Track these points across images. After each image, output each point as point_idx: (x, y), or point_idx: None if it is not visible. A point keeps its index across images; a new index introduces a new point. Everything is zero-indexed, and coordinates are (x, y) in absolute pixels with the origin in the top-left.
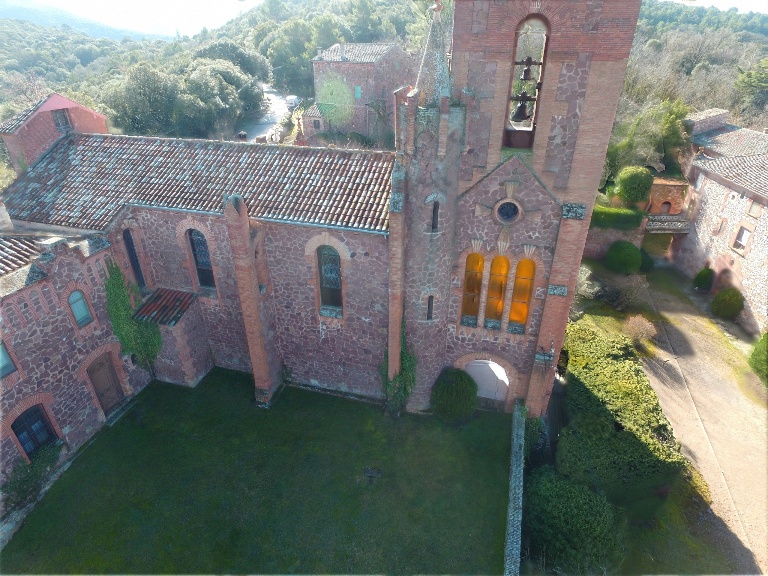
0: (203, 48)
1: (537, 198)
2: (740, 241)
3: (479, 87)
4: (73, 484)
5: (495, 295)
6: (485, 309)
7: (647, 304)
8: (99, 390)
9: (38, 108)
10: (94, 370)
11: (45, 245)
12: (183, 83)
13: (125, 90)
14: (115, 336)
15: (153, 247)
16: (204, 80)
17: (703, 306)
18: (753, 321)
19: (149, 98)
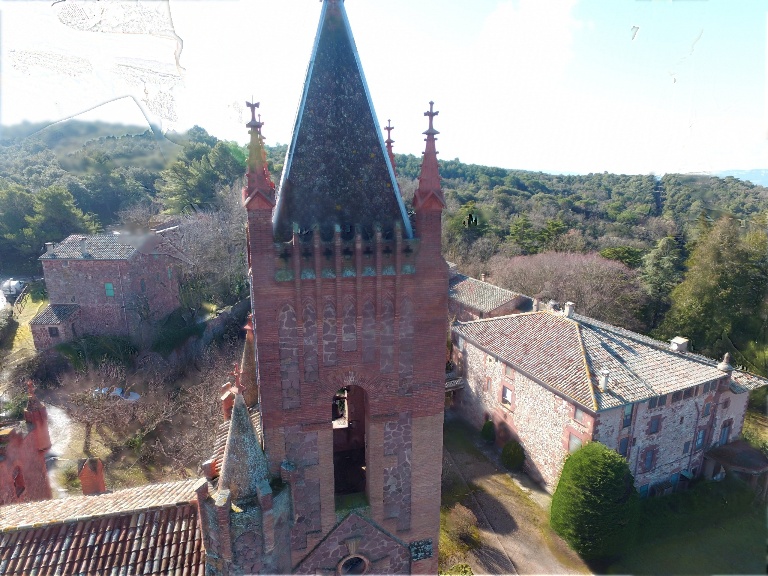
0: None
1: (382, 546)
2: (506, 398)
3: (300, 457)
4: None
5: None
6: None
7: (455, 474)
8: None
9: None
10: None
11: None
12: None
13: None
14: None
15: None
16: None
17: (496, 460)
18: (536, 469)
19: None
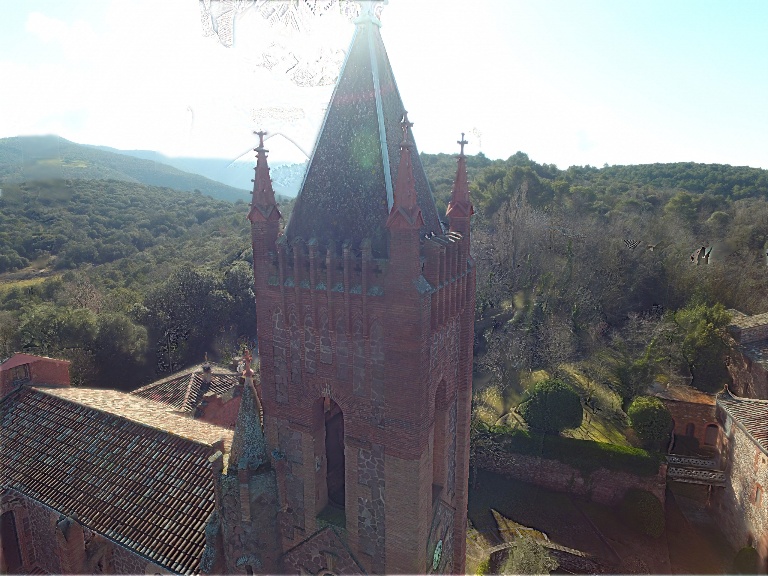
0: None
1: None
2: None
3: (289, 451)
4: None
5: None
6: None
7: None
8: None
9: None
10: None
11: None
12: (223, 276)
13: (165, 287)
14: None
15: (35, 526)
16: (242, 273)
17: None
18: None
19: (186, 293)
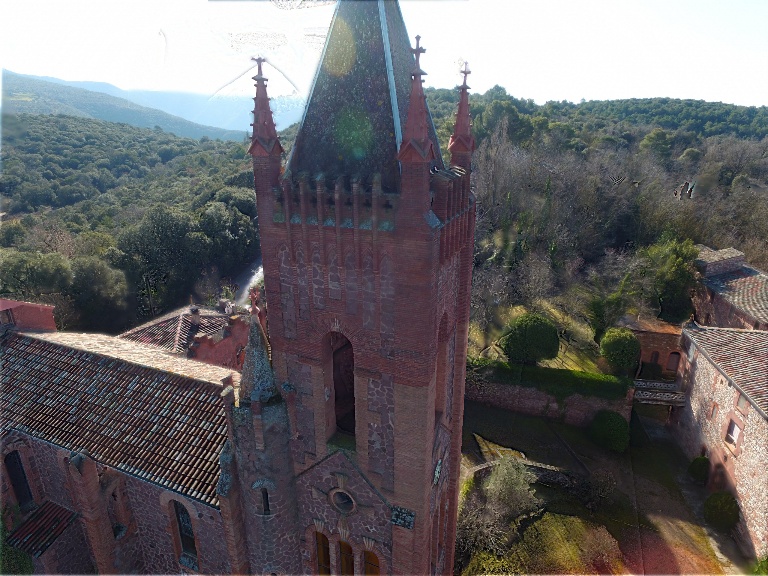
0: (234, 175)
1: (368, 495)
2: (732, 436)
3: (299, 383)
4: None
5: (349, 573)
6: None
7: (627, 498)
8: None
9: None
10: None
11: None
12: (198, 218)
13: (139, 230)
14: None
15: (41, 464)
16: (218, 214)
17: (696, 506)
18: (749, 541)
19: (161, 235)
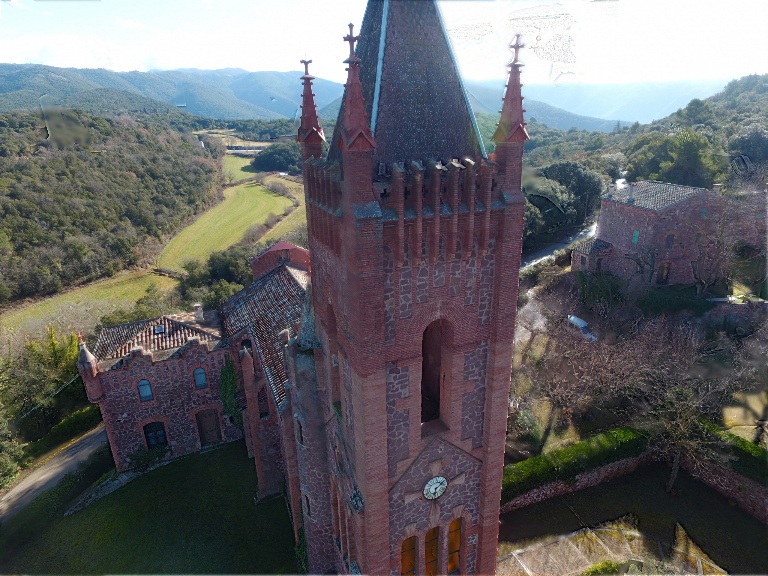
0: (546, 167)
1: None
2: None
3: (323, 344)
4: (159, 475)
5: None
6: (345, 541)
7: None
8: (205, 429)
9: (269, 249)
10: (205, 416)
11: (187, 340)
12: None
13: None
14: (221, 401)
15: None
16: None
17: None
18: None
19: None
